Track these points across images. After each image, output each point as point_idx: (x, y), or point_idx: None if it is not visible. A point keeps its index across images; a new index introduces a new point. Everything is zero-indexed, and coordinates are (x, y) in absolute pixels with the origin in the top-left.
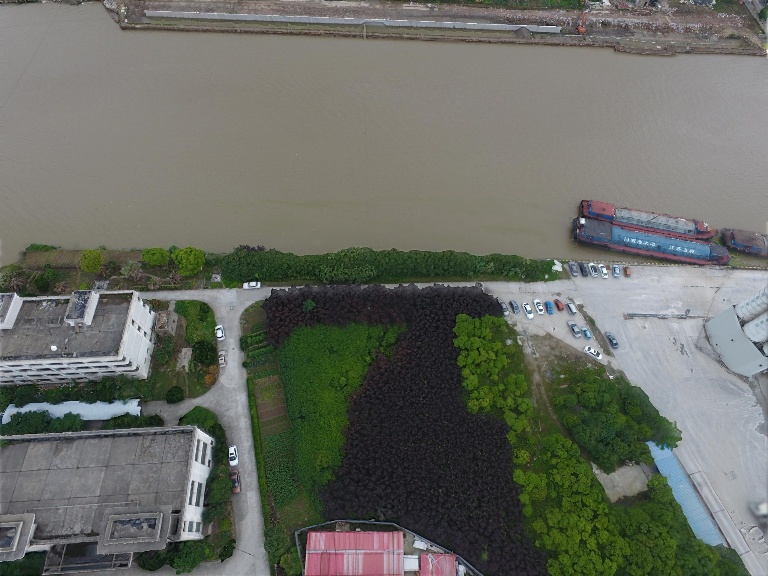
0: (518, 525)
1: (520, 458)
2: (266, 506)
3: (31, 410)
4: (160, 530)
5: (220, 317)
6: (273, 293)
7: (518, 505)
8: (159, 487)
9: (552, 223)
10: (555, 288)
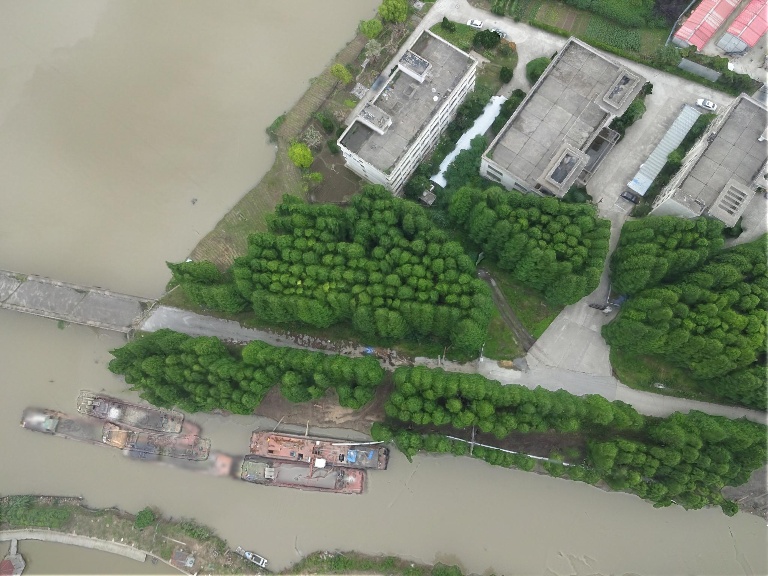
0: None
1: None
2: (634, 56)
3: (448, 165)
4: None
5: (459, 19)
6: None
7: None
8: (595, 78)
9: None
10: None
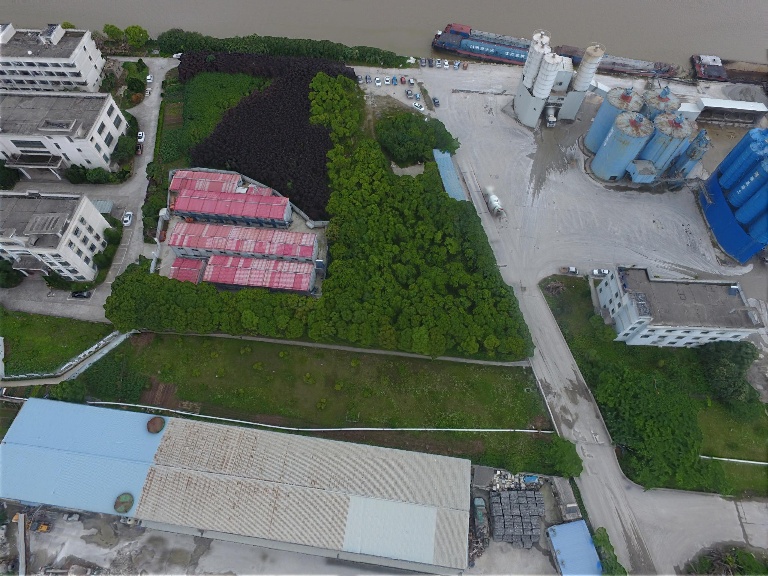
0: None
1: None
2: (155, 161)
3: None
4: (73, 127)
5: (153, 72)
6: (188, 51)
7: (324, 168)
8: None
9: (420, 38)
10: (405, 72)
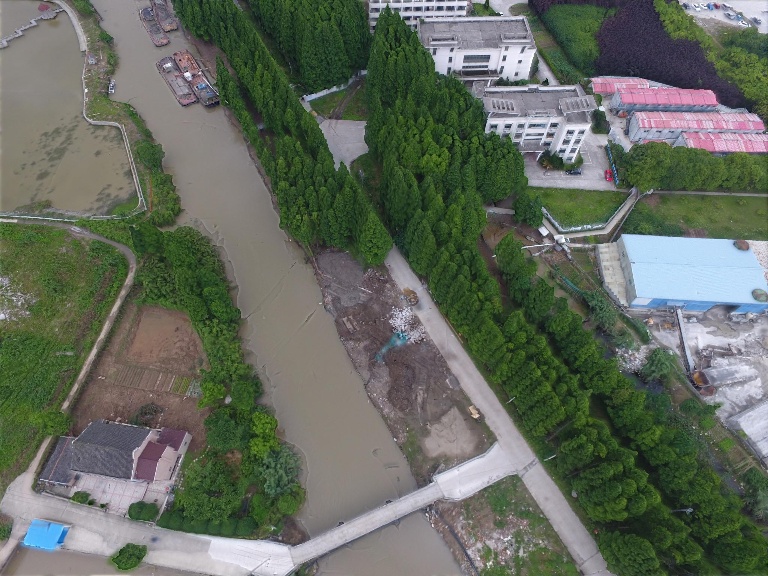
0: (715, 76)
1: (710, 55)
2: (558, 74)
3: None
4: None
5: (496, 10)
6: None
7: (713, 69)
8: None
9: None
10: (711, 0)
